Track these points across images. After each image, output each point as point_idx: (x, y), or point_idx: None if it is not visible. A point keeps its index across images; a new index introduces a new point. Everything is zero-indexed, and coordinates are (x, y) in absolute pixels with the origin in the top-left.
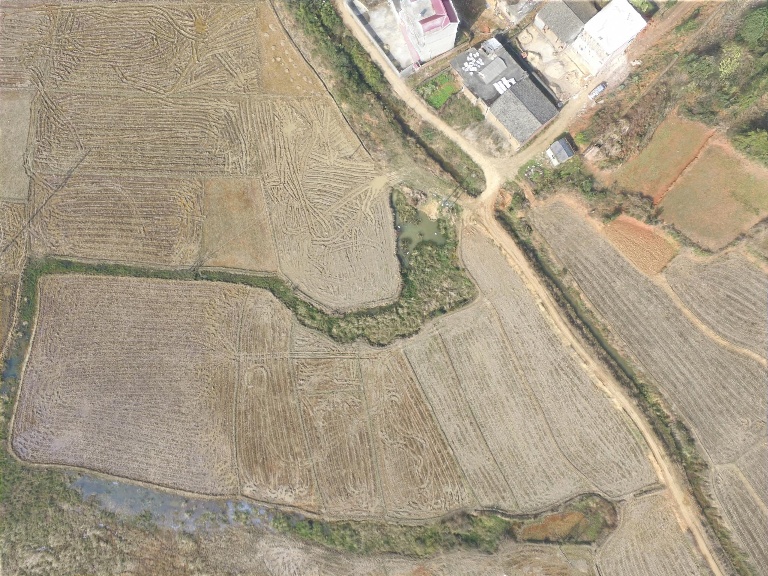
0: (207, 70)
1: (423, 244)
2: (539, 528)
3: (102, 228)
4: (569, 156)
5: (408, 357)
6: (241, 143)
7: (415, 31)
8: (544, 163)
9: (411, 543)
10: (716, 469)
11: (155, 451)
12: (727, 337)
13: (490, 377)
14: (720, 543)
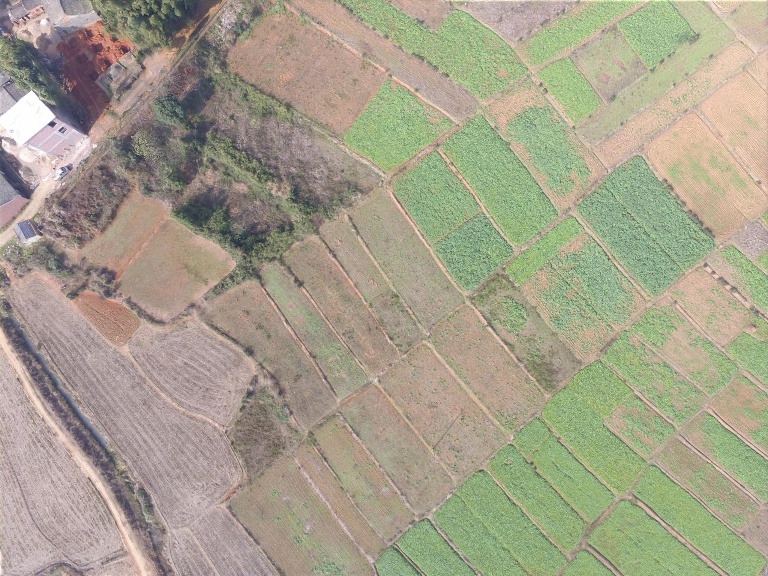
0: None
1: None
2: None
3: None
4: (27, 237)
5: None
6: None
7: None
8: None
9: None
10: (173, 533)
11: None
12: (183, 403)
13: None
14: None
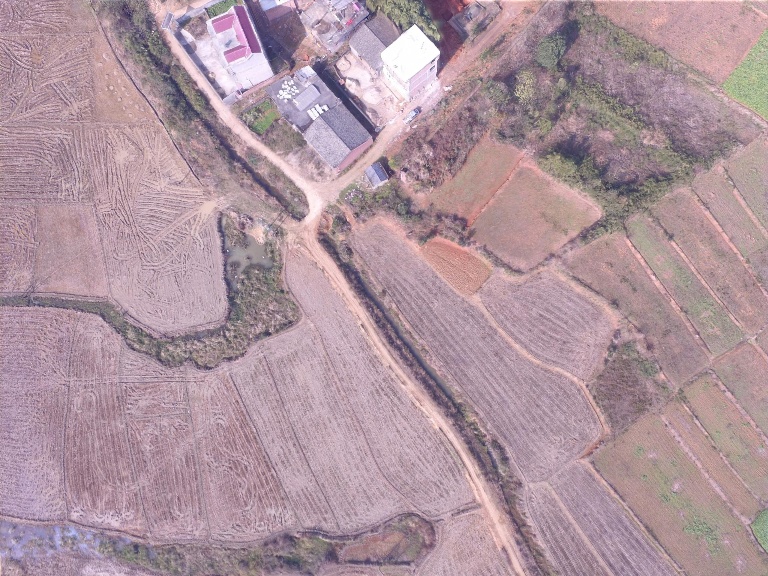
0: (42, 99)
1: (251, 267)
2: (360, 549)
3: None
4: (382, 180)
5: (234, 380)
6: (74, 170)
7: (220, 62)
8: (364, 187)
9: (235, 566)
10: (530, 487)
11: None
12: (539, 356)
13: (313, 398)
14: (535, 561)
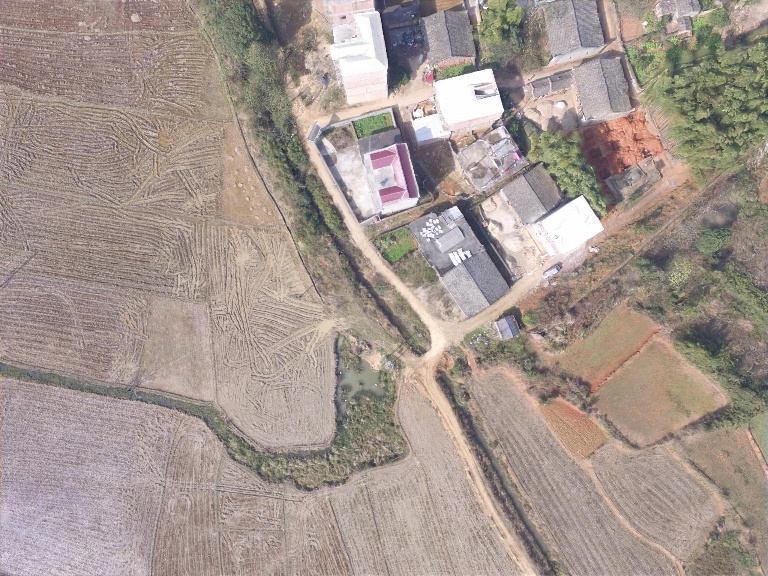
0: (166, 186)
1: (362, 393)
2: None
3: (41, 335)
4: (514, 336)
5: (332, 505)
6: (192, 266)
7: (374, 200)
8: (491, 333)
9: None
10: None
11: (70, 566)
12: (642, 530)
13: (409, 535)
14: None
